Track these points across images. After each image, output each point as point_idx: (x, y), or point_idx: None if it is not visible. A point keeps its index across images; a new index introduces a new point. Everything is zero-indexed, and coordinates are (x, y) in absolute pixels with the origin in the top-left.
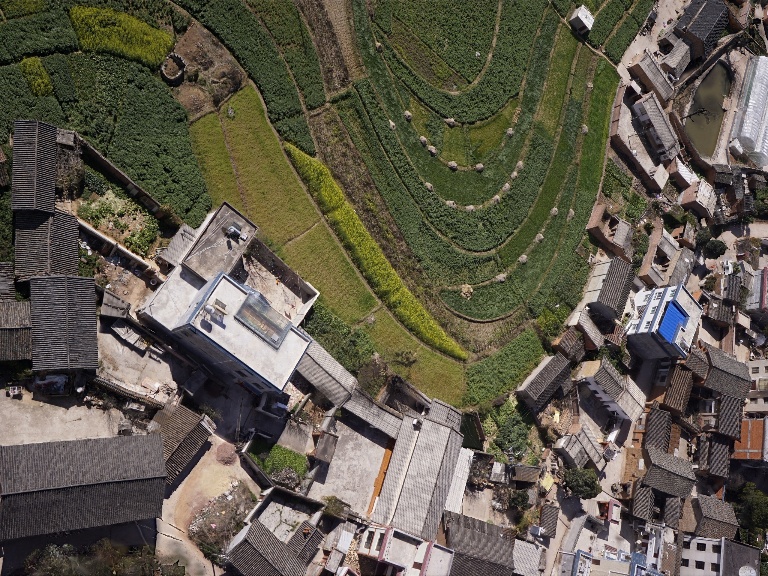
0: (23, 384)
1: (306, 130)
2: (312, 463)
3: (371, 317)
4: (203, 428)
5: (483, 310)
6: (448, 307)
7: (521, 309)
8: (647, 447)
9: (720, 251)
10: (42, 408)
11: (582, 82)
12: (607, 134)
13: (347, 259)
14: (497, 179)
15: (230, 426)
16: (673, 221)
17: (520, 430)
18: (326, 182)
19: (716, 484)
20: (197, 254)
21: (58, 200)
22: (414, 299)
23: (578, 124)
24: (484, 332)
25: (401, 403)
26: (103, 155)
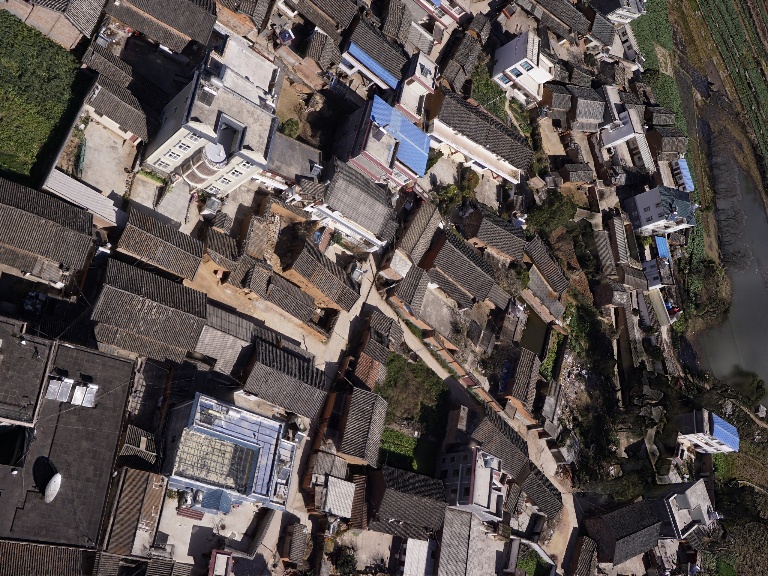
0: None
1: None
2: None
3: None
4: None
5: None
6: None
7: None
8: None
9: None
10: (625, 572)
11: None
12: None
13: None
14: None
15: None
16: None
17: None
18: None
19: None
20: None
21: None
22: None
23: None
24: None
25: None
26: None
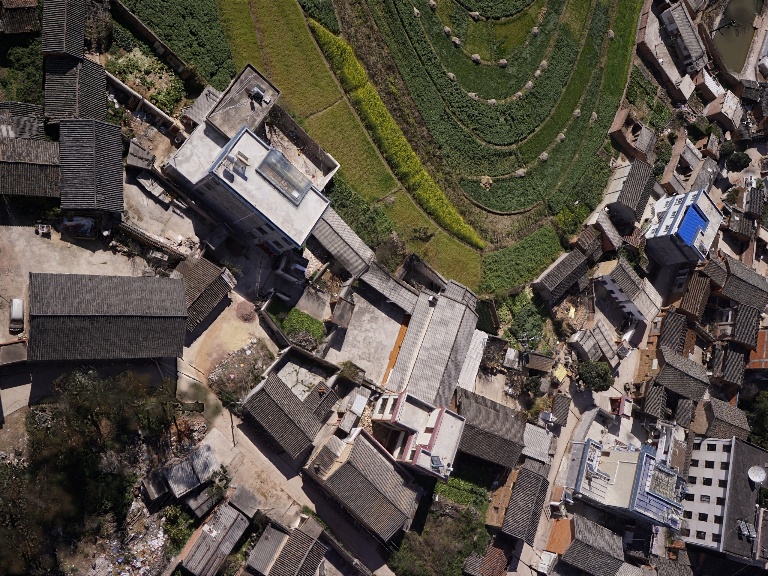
0: (52, 224)
1: (330, 8)
2: (329, 329)
3: (390, 197)
4: (224, 281)
5: (502, 202)
6: (467, 196)
7: (540, 205)
8: (661, 347)
9: (744, 163)
10: (69, 249)
11: None
12: (633, 41)
13: (368, 139)
14: (520, 76)
15: (250, 286)
16: (697, 132)
17: (535, 321)
18: (349, 60)
19: (730, 393)
20: (221, 112)
21: (87, 52)
22: (433, 183)
23: (604, 29)
24: (502, 224)
25: (418, 283)
26: (131, 13)
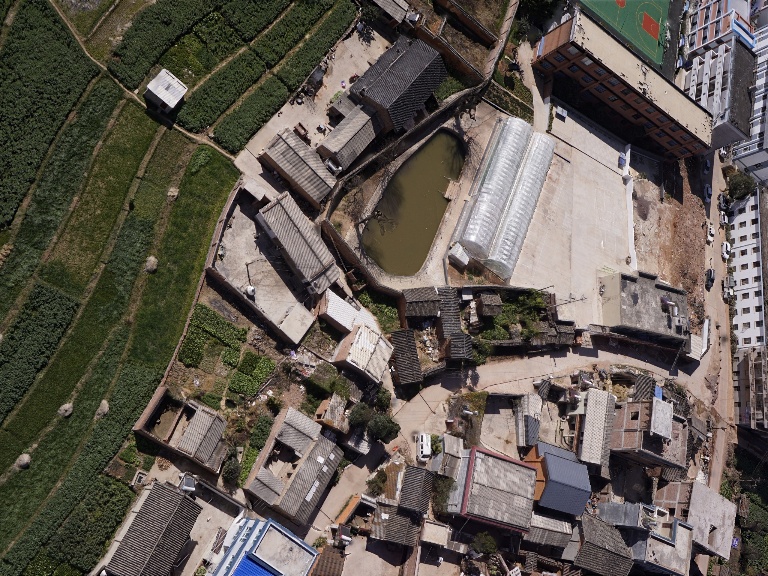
0: None
1: None
2: None
3: None
4: None
5: None
6: None
7: None
8: None
9: (389, 434)
10: None
11: (161, 187)
12: (202, 265)
13: None
14: None
15: None
16: (318, 390)
17: None
18: None
19: None
20: None
21: None
22: None
23: (141, 256)
24: None
25: None
26: None
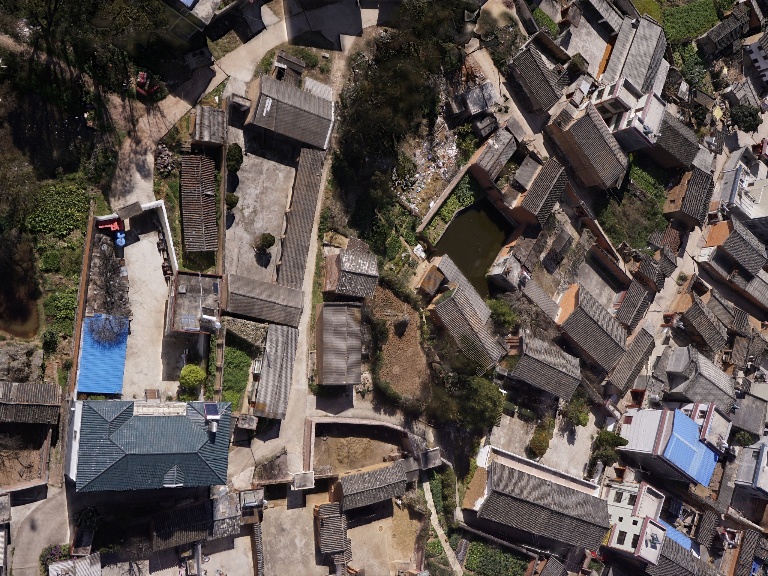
0: None
1: None
2: (562, 29)
3: None
4: None
5: None
6: None
7: None
8: None
9: None
10: None
11: None
12: None
13: None
14: None
15: None
16: None
17: (699, 69)
18: None
19: None
20: None
21: None
22: None
23: None
24: None
25: None
26: None
